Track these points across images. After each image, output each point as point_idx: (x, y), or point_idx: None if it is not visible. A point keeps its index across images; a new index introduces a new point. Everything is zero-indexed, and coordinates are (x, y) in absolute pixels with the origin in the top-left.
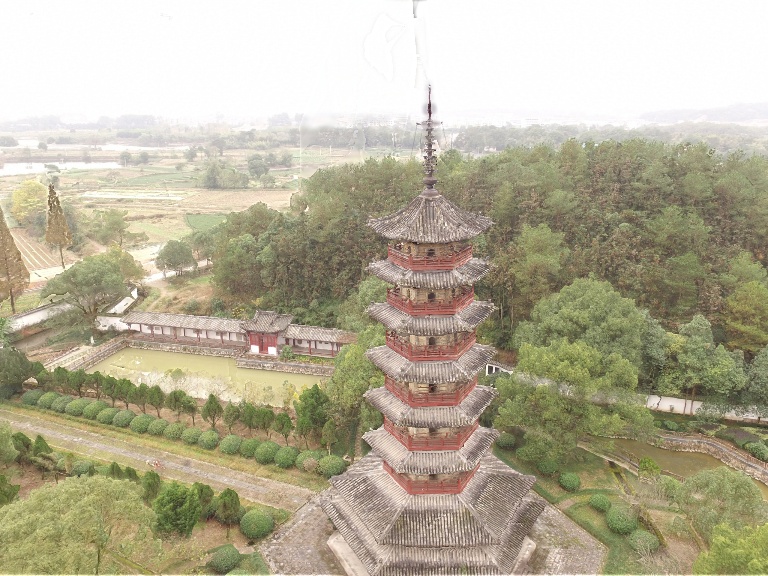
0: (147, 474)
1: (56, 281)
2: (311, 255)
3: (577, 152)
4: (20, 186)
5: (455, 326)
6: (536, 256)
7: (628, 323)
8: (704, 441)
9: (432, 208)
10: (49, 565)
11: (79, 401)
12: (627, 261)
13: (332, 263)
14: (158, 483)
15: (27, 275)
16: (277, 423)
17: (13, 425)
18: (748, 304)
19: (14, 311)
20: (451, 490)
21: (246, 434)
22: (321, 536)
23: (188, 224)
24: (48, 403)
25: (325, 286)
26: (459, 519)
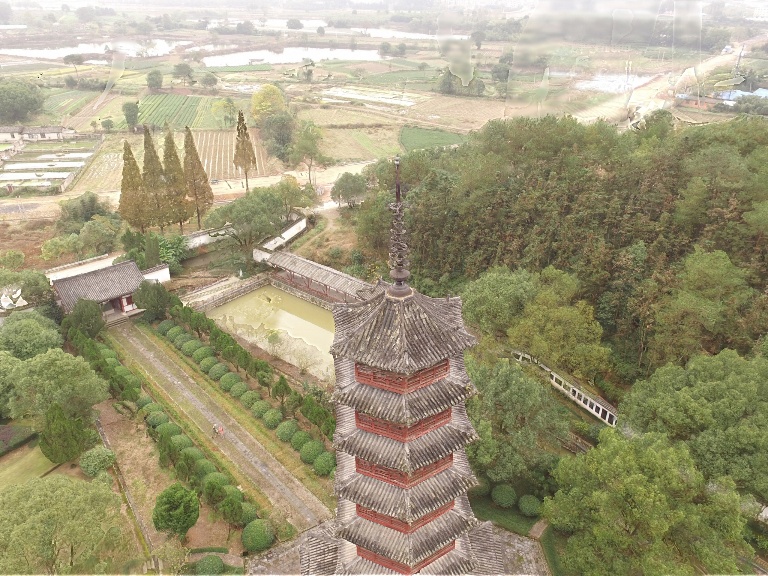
0: (183, 454)
1: (216, 215)
2: (448, 226)
3: None
4: (259, 89)
5: (397, 460)
6: (687, 299)
7: None
8: None
9: (393, 312)
10: None
11: (193, 343)
12: None
13: (469, 239)
14: (192, 464)
15: (211, 197)
16: (324, 428)
17: (142, 352)
18: None
19: (200, 227)
20: None
21: (307, 422)
22: None
23: (399, 139)
24: (173, 337)
25: (458, 262)
26: None
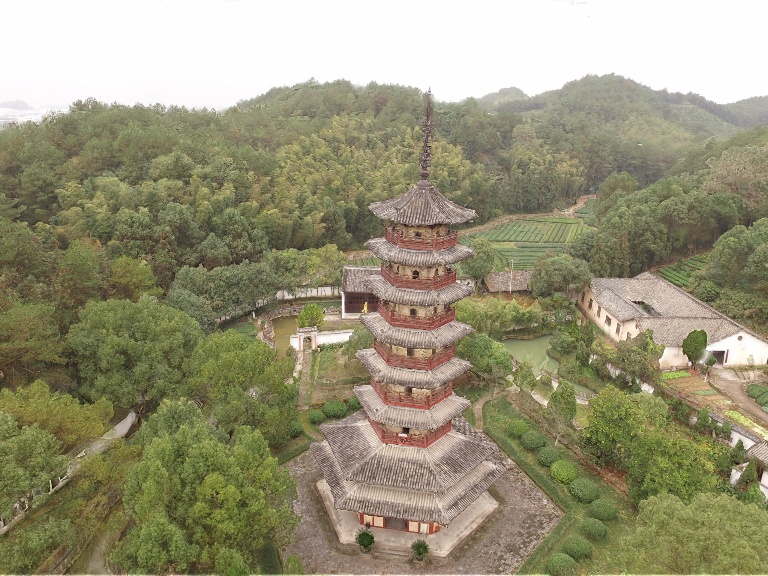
0: None
1: None
2: None
3: None
4: None
5: None
6: (25, 310)
7: None
8: None
9: None
10: None
11: None
12: (11, 290)
13: None
14: None
15: None
16: None
17: None
18: (136, 274)
19: None
20: None
21: None
22: (437, 567)
23: None
24: None
25: None
26: None
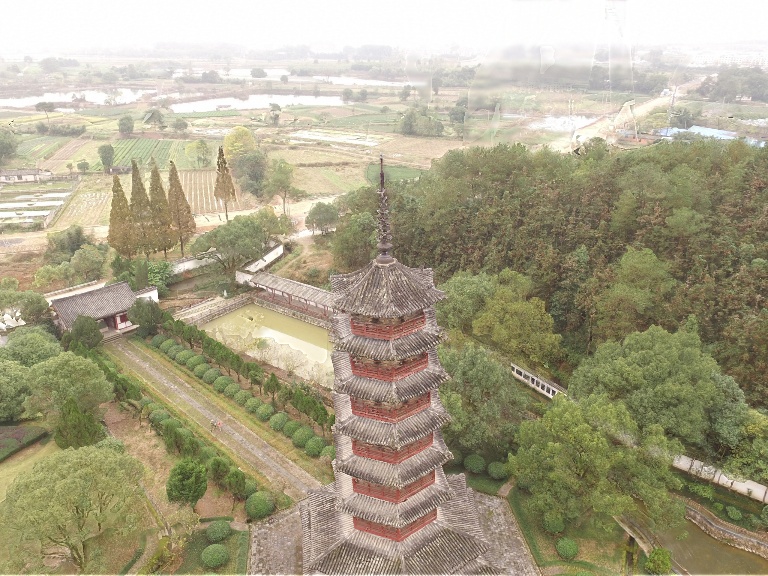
0: (188, 439)
1: (201, 239)
2: (416, 242)
3: (745, 155)
4: (231, 131)
5: (387, 395)
6: (622, 288)
7: (690, 392)
8: (765, 544)
9: (380, 276)
10: (35, 519)
11: (186, 352)
12: (745, 307)
13: (435, 253)
14: (196, 448)
15: (194, 226)
16: (313, 414)
17: (138, 363)
18: None
19: (183, 254)
20: (391, 537)
21: (297, 414)
22: None
23: (366, 175)
24: (167, 349)
25: None
26: (388, 567)
